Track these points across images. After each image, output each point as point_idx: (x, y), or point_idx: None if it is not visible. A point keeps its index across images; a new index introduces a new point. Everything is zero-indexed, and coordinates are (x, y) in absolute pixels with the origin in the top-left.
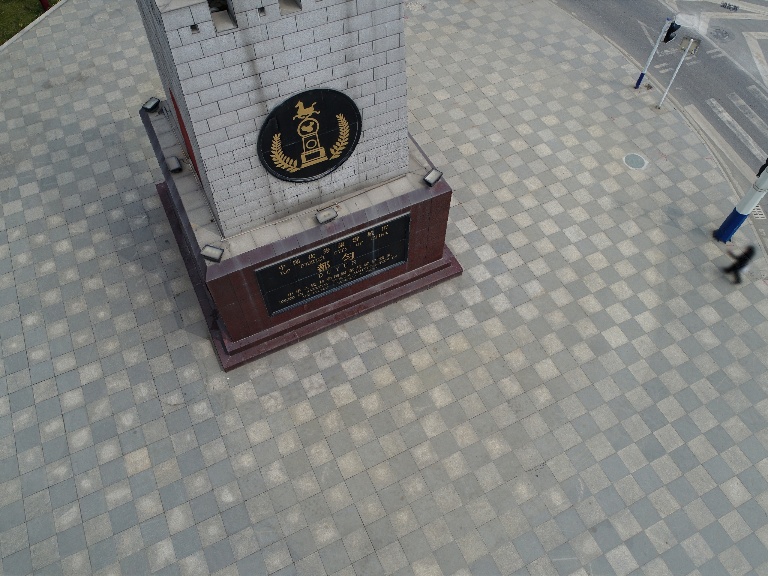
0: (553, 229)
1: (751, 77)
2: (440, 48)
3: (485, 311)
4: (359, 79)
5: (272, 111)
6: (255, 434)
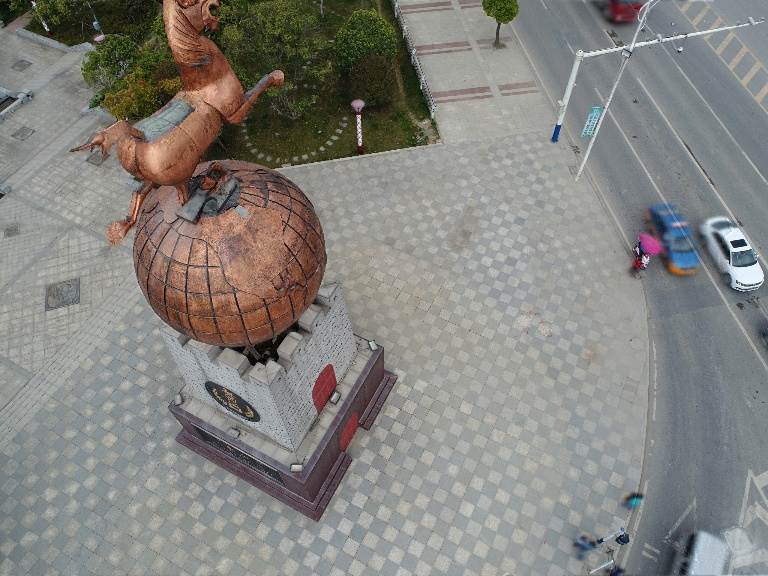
0: (396, 559)
1: None
2: (514, 375)
3: (299, 554)
4: (255, 404)
5: (211, 381)
6: (150, 483)
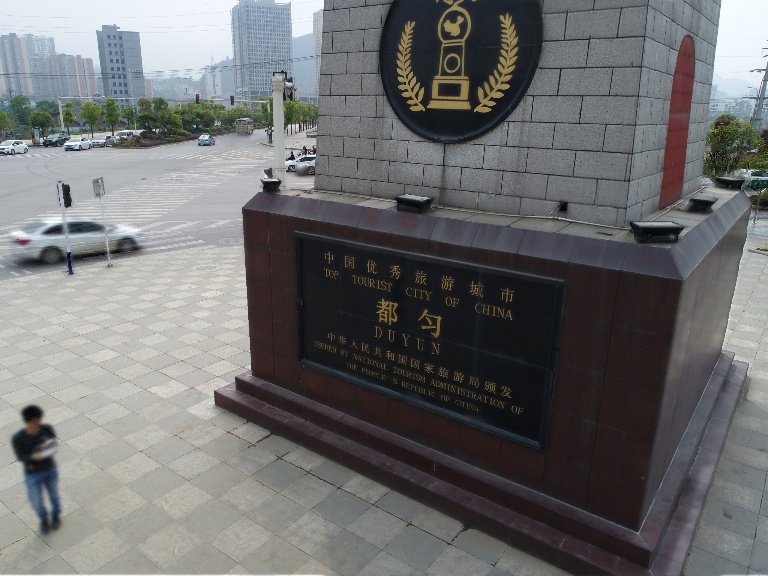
0: None
1: (45, 249)
2: None
3: None
4: None
5: None
6: (749, 344)
